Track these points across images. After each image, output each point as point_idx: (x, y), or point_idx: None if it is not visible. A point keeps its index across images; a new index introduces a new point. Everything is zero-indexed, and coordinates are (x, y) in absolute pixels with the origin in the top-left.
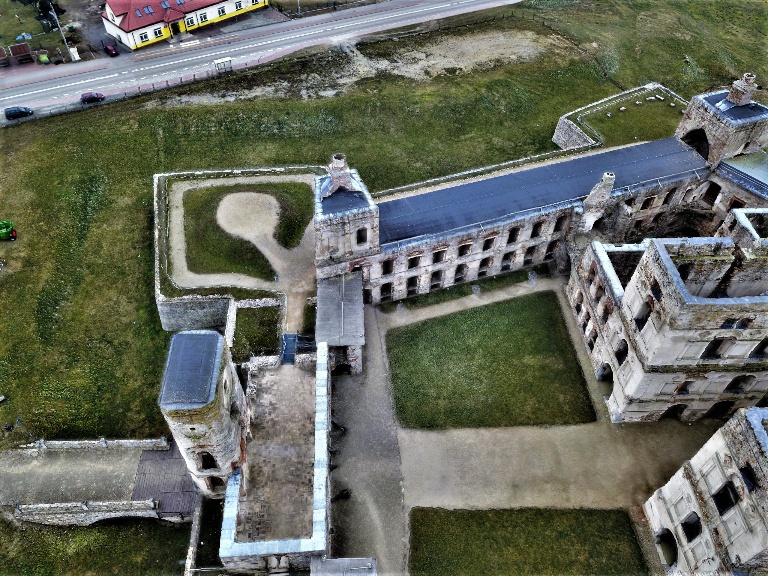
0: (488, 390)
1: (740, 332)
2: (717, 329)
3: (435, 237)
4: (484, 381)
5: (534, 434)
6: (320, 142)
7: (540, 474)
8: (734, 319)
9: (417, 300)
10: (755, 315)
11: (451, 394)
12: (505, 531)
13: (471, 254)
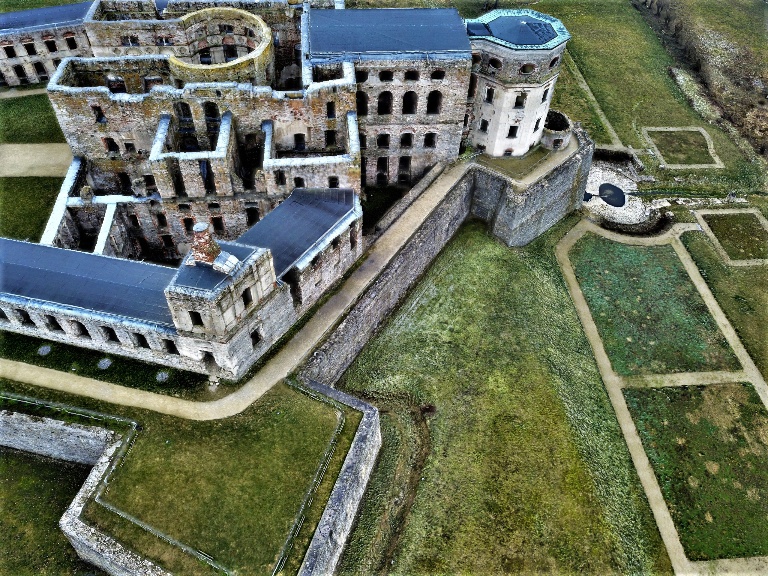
0: (45, 127)
1: (139, 50)
2: (121, 46)
3: (19, 31)
4: (46, 123)
5: (62, 146)
6: (17, 6)
7: (52, 163)
8: (125, 37)
9: (28, 86)
10: (135, 33)
11: (18, 129)
12: (8, 185)
13: (59, 50)
